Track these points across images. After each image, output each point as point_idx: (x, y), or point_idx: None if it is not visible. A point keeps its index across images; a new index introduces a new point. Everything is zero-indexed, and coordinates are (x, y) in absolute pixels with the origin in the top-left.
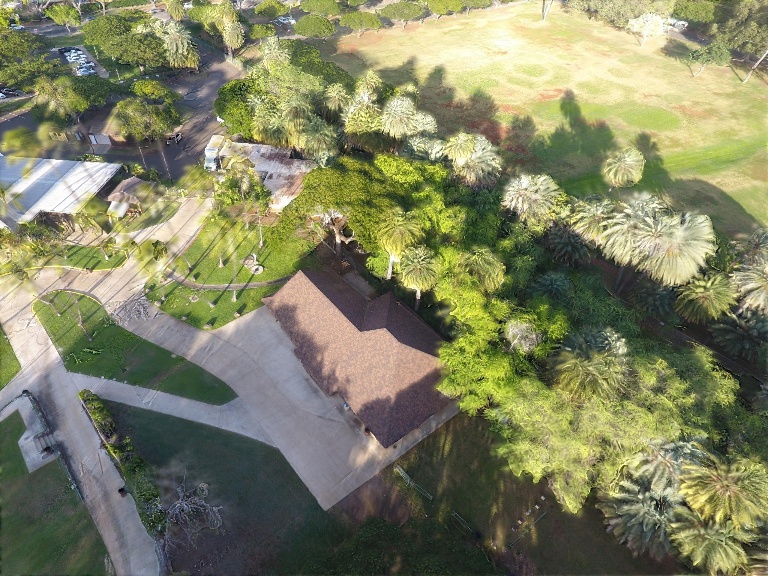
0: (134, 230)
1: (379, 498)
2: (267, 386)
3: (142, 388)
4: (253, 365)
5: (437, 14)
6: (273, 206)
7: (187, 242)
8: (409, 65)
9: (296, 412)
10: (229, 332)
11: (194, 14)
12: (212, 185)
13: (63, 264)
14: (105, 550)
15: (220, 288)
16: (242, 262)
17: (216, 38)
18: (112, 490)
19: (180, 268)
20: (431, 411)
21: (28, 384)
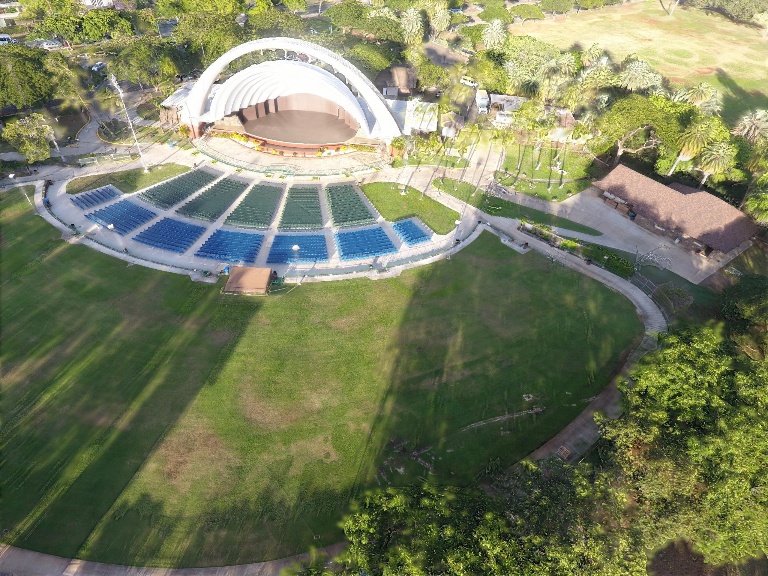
0: (460, 147)
1: (724, 282)
2: (617, 230)
3: (546, 225)
4: (600, 220)
5: (580, 8)
6: (547, 136)
7: (501, 155)
8: (578, 47)
9: (645, 243)
10: (571, 204)
11: (395, 4)
12: (490, 123)
13: (431, 164)
14: (601, 283)
15: (545, 181)
16: (549, 168)
17: (423, 23)
18: (579, 262)
19: (510, 169)
20: (743, 239)
21: (473, 220)
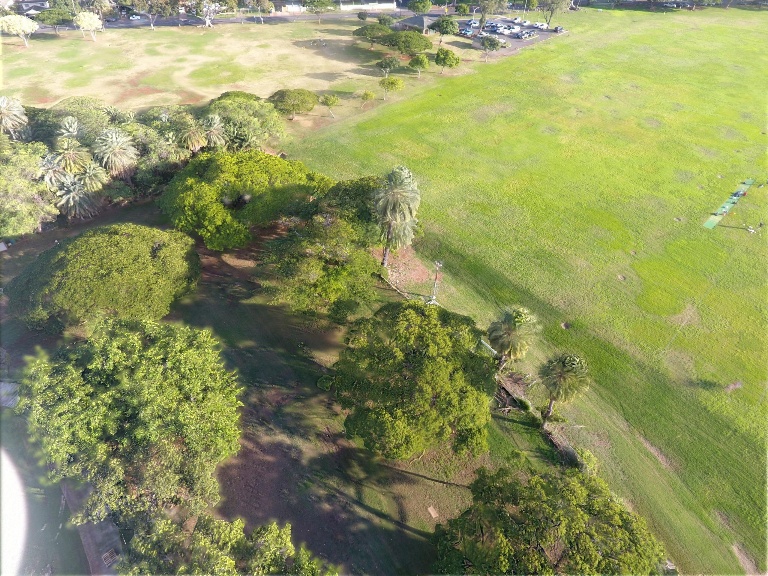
0: None
1: (4, 306)
2: None
3: None
4: None
5: None
6: None
7: None
8: None
9: None
10: None
11: None
12: None
13: None
14: None
15: None
16: None
17: None
18: None
19: None
20: None
21: None
